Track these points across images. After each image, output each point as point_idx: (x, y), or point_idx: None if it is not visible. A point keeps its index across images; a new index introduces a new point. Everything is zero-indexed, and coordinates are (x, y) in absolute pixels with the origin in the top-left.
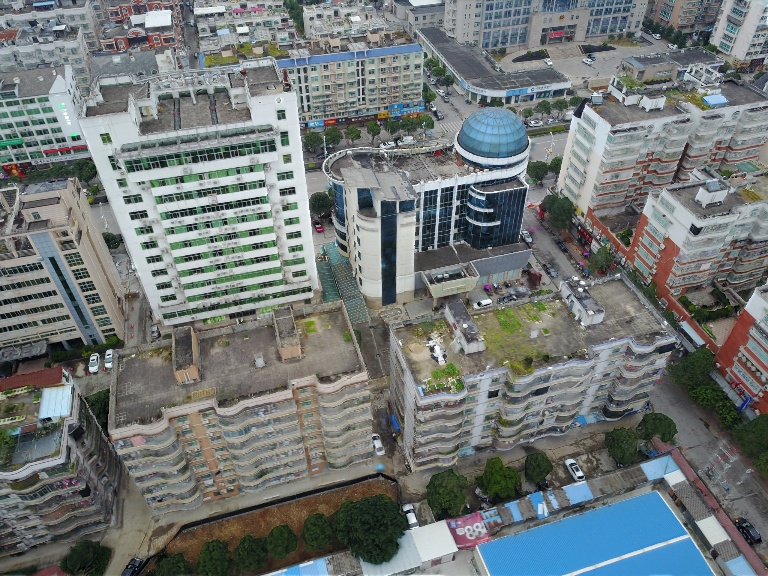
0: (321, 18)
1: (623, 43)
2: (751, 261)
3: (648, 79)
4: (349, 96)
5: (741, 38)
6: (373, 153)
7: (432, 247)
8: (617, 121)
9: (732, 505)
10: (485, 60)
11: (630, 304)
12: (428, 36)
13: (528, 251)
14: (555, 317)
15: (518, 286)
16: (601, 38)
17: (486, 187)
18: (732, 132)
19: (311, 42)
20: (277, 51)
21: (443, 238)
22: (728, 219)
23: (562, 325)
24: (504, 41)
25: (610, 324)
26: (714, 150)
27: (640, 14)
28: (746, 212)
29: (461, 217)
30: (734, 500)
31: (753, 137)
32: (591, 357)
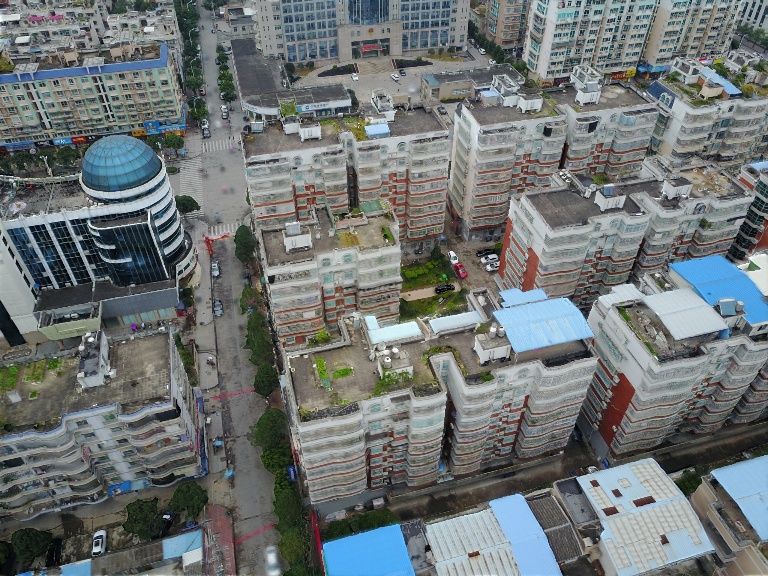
0: (126, 27)
1: (444, 58)
2: (371, 309)
3: (444, 97)
4: (93, 113)
5: (542, 56)
6: (4, 182)
7: (70, 283)
8: (262, 152)
9: None
10: (279, 75)
11: (154, 363)
12: (237, 48)
13: (171, 290)
14: (60, 377)
15: (172, 326)
16: (422, 52)
17: (107, 222)
18: (404, 164)
19: (48, 56)
20: (4, 65)
21: (81, 274)
22: (304, 267)
23: (60, 387)
24: (314, 54)
25: (113, 387)
26: (391, 182)
27: (463, 28)
28: (337, 258)
29: (93, 252)
30: None
31: (430, 169)
32: None
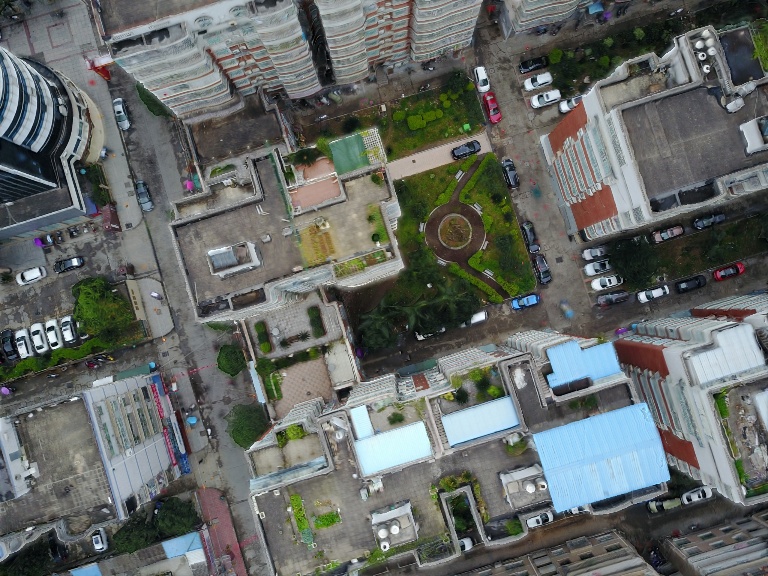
0: None
1: None
2: None
3: None
4: None
5: None
6: None
7: None
8: (131, 6)
9: (261, 571)
10: None
11: (82, 452)
12: None
13: (67, 210)
14: None
15: (89, 233)
16: None
17: None
18: None
19: None
20: None
21: None
22: (252, 308)
23: None
24: None
25: (42, 491)
26: (383, 9)
27: None
28: None
29: None
30: (265, 565)
31: None
32: (3, 550)
